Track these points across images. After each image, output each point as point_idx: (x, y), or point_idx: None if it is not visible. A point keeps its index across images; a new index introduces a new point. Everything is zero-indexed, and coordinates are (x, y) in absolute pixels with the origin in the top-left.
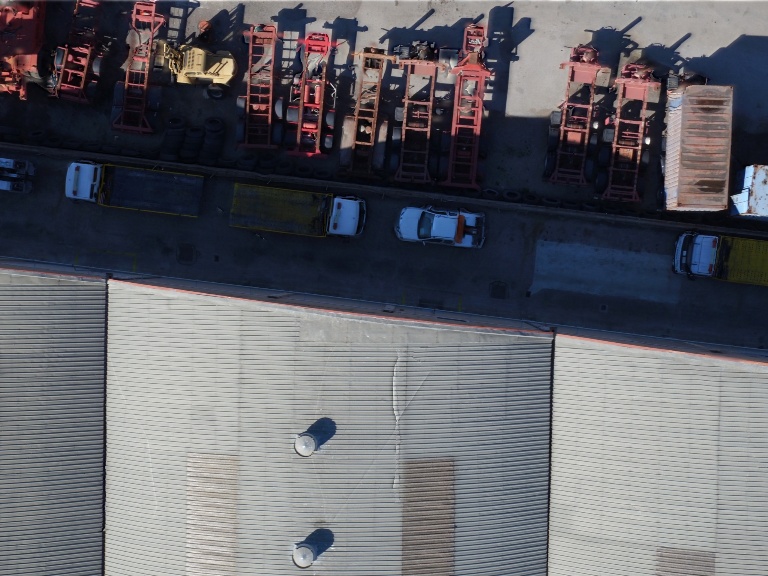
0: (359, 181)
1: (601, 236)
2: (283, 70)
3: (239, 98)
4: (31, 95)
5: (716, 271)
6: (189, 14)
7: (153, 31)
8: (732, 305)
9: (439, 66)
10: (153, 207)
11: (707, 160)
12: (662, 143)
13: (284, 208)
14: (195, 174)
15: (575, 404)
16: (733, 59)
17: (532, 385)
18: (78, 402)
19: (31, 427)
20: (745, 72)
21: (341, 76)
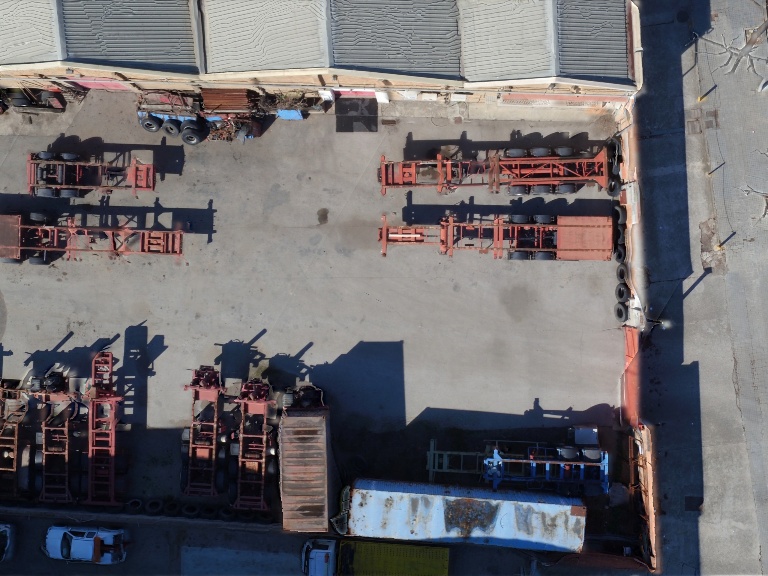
0: (7, 503)
1: (241, 539)
2: None
3: None
4: None
5: (340, 575)
6: None
7: None
8: None
9: (70, 395)
10: None
11: (306, 487)
12: (278, 461)
13: None
14: None
15: None
16: (353, 365)
17: None
18: None
19: None
20: (366, 376)
21: None
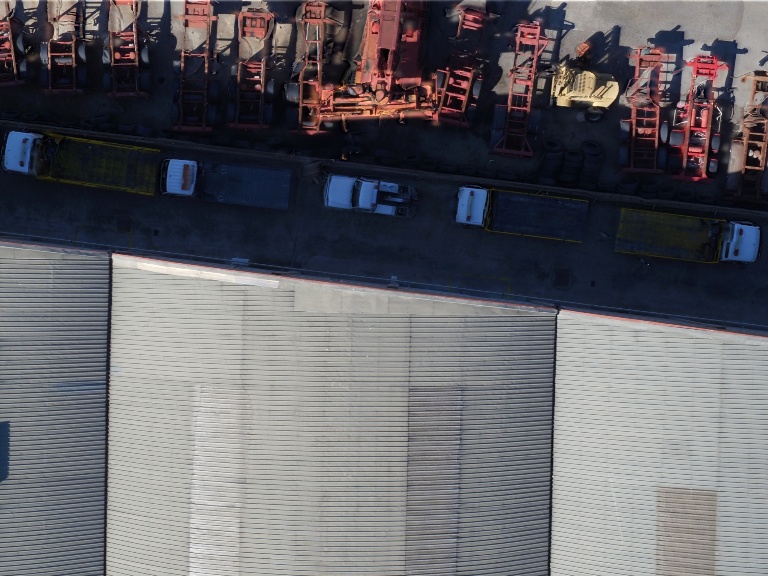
0: (746, 206)
1: None
2: (660, 93)
3: (622, 122)
4: (409, 118)
5: None
6: (563, 36)
7: (537, 54)
8: None
9: None
10: (536, 232)
11: None
12: None
13: (671, 233)
14: (580, 199)
15: None
16: None
17: None
18: (530, 434)
19: (489, 460)
20: None
21: (719, 99)
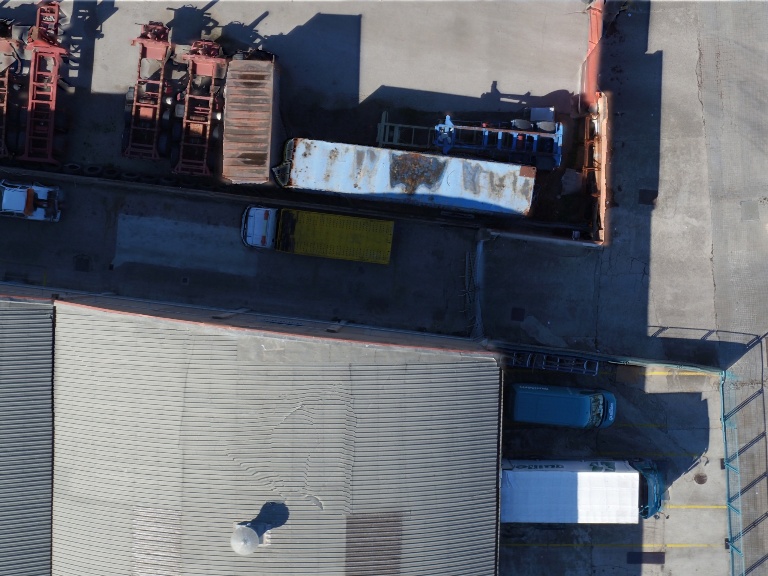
0: None
1: (181, 210)
2: None
3: None
4: None
5: (279, 243)
6: None
7: None
8: (308, 278)
9: (12, 42)
10: None
11: (249, 133)
12: (223, 118)
13: None
14: None
15: (72, 368)
16: (309, 37)
17: (32, 350)
18: None
19: None
20: (321, 50)
21: None
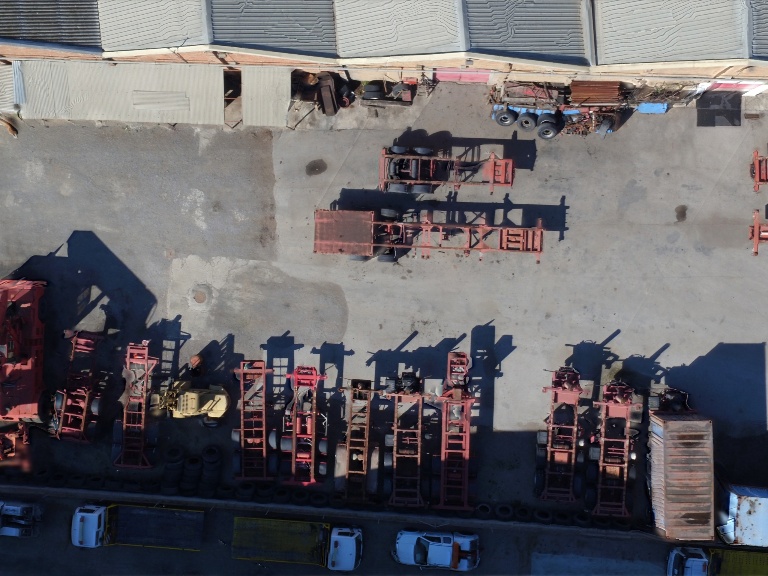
0: (354, 507)
1: (594, 546)
2: (275, 396)
3: (234, 431)
4: (34, 438)
5: None
6: (181, 346)
7: (147, 373)
8: None
9: (425, 396)
10: (157, 542)
11: (691, 493)
12: (647, 466)
13: (283, 538)
14: (195, 510)
15: None
16: (713, 367)
17: None
18: None
19: None
20: (725, 379)
21: (331, 399)
